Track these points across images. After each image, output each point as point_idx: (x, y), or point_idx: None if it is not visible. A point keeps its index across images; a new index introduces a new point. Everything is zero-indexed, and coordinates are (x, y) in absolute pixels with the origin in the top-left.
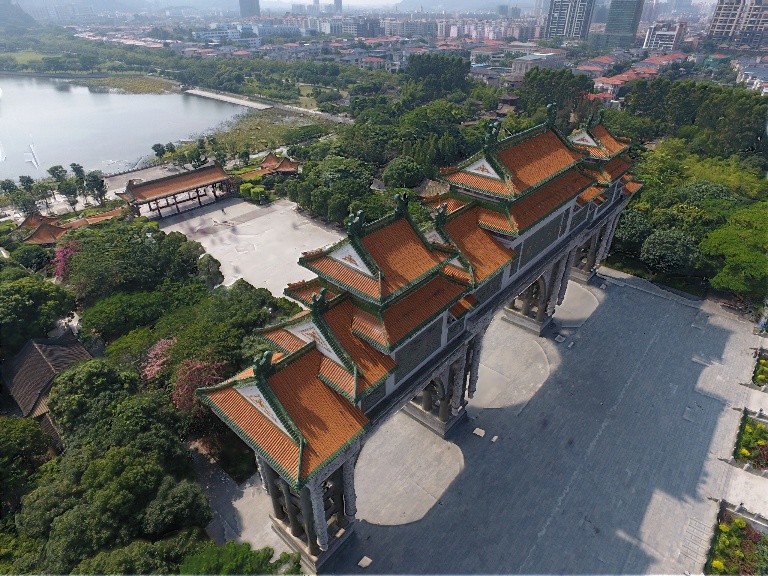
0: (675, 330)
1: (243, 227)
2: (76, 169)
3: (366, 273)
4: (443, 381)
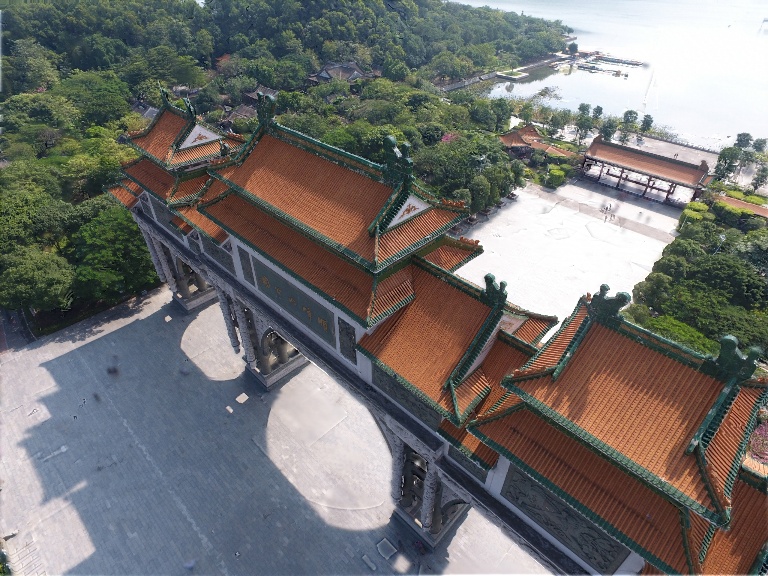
0: None
1: (607, 227)
2: (647, 121)
3: None
4: None
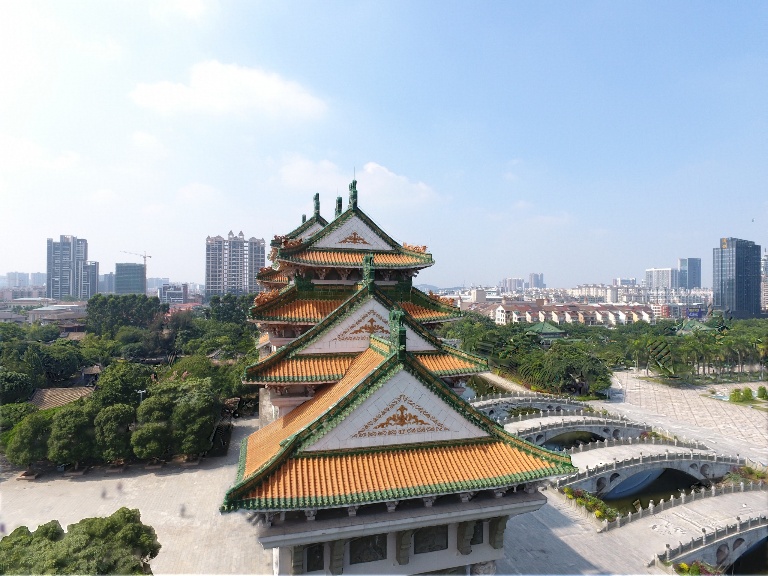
0: None
1: None
2: None
3: (381, 250)
4: None
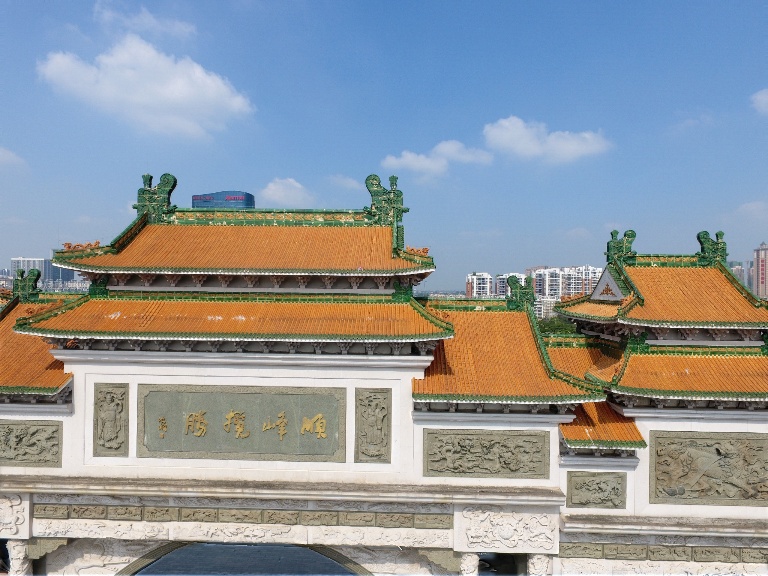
0: None
1: None
2: None
3: None
4: None
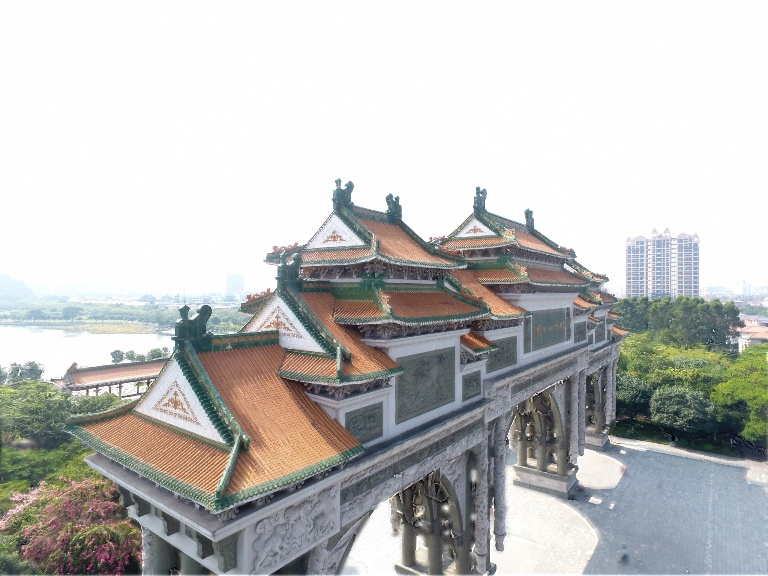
0: (731, 488)
1: None
2: (16, 369)
3: (355, 245)
4: (459, 499)
